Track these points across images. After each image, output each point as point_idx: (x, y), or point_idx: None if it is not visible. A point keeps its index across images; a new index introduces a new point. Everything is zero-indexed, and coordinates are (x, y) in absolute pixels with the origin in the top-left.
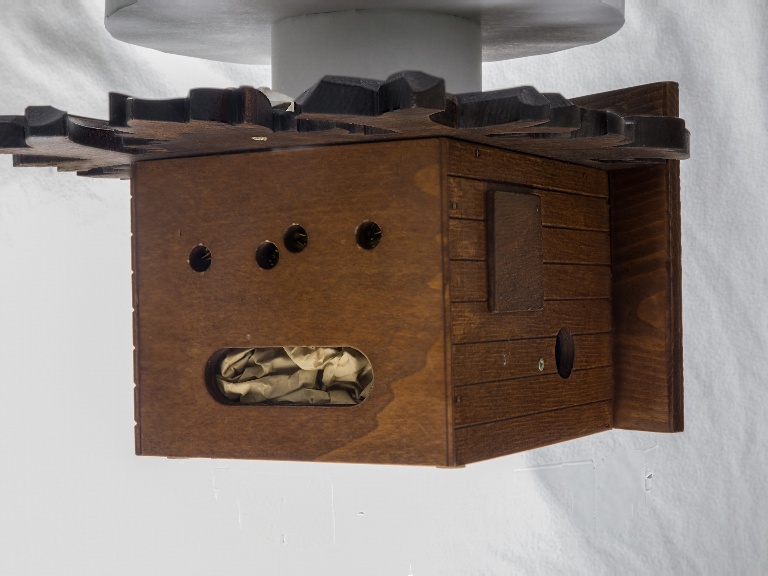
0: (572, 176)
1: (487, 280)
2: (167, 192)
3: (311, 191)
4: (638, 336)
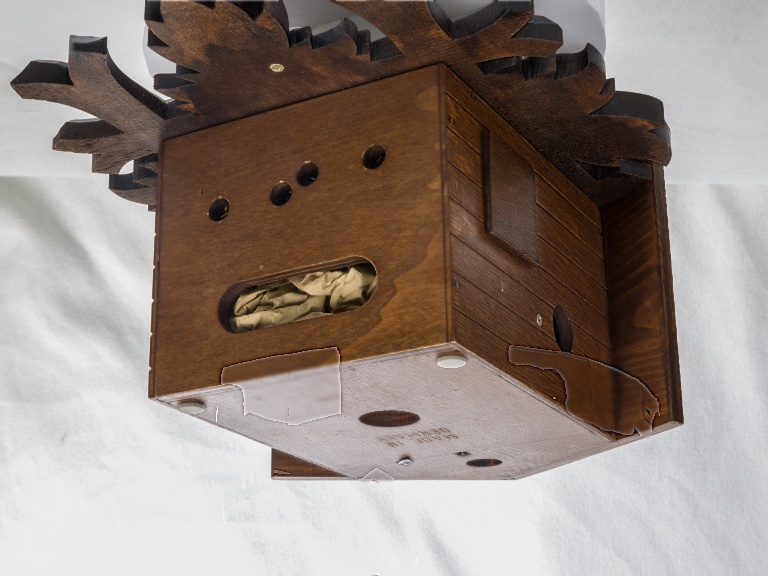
0: (565, 185)
1: (484, 206)
2: (191, 159)
3: (322, 131)
4: (635, 343)
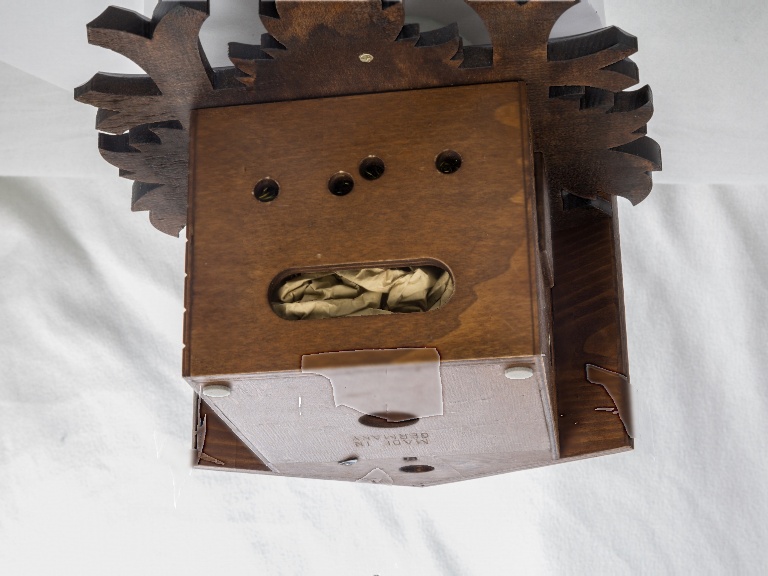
0: None
1: (537, 224)
2: (231, 134)
3: (389, 127)
4: None
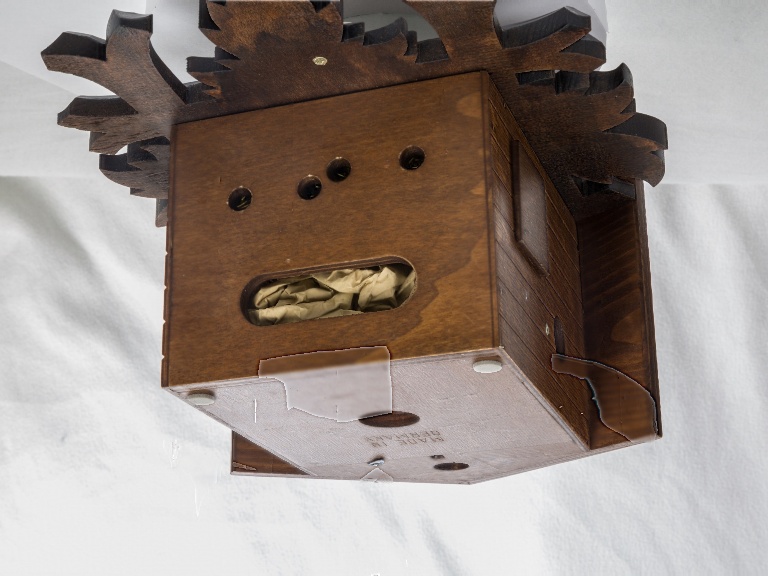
0: (556, 198)
1: (513, 214)
2: (208, 146)
3: (355, 128)
4: (613, 357)
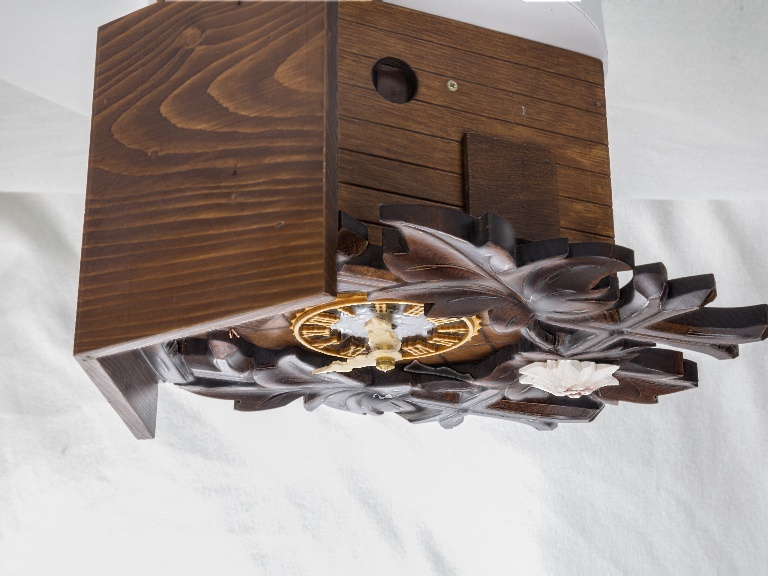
0: None
1: None
2: None
3: None
4: None
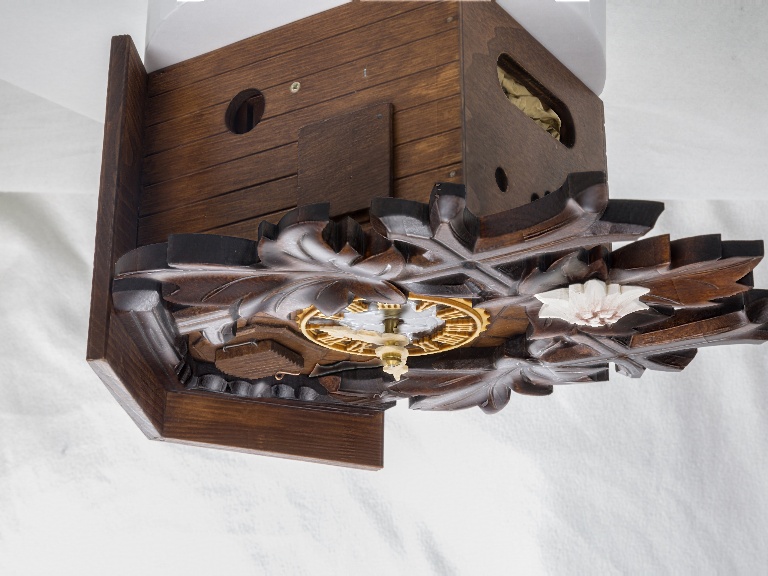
0: None
1: (394, 130)
2: None
3: None
4: None
